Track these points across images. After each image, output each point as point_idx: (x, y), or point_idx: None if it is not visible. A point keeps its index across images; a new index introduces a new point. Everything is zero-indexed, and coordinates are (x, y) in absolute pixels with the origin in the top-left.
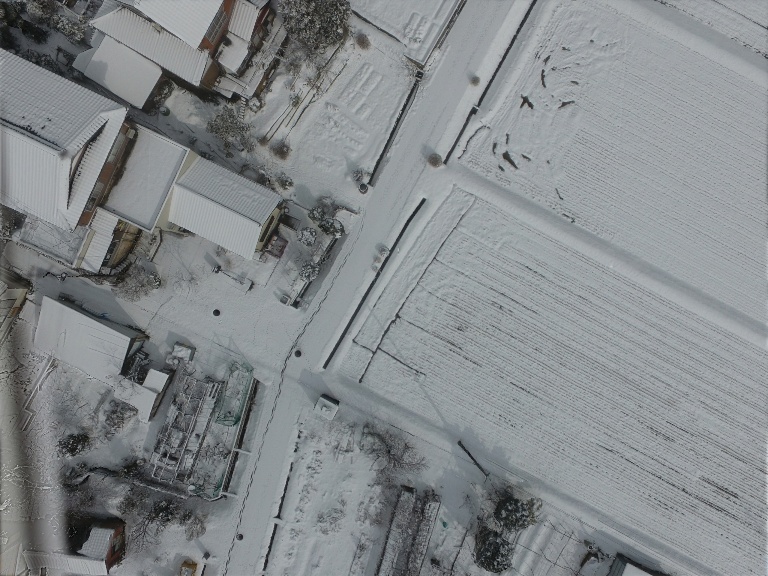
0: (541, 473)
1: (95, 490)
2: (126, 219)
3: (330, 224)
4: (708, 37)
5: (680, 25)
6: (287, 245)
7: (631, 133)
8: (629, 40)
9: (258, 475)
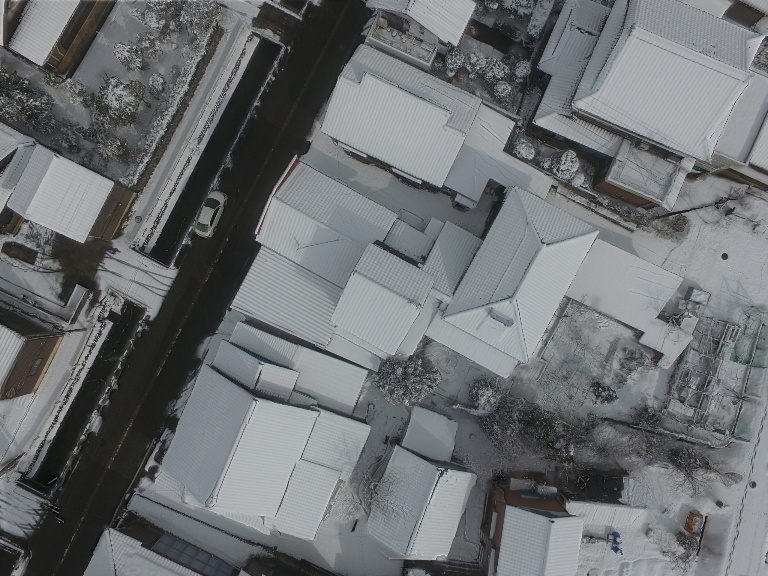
0: None
1: (603, 441)
2: (720, 153)
3: None
4: None
5: None
6: None
7: None
8: None
9: None
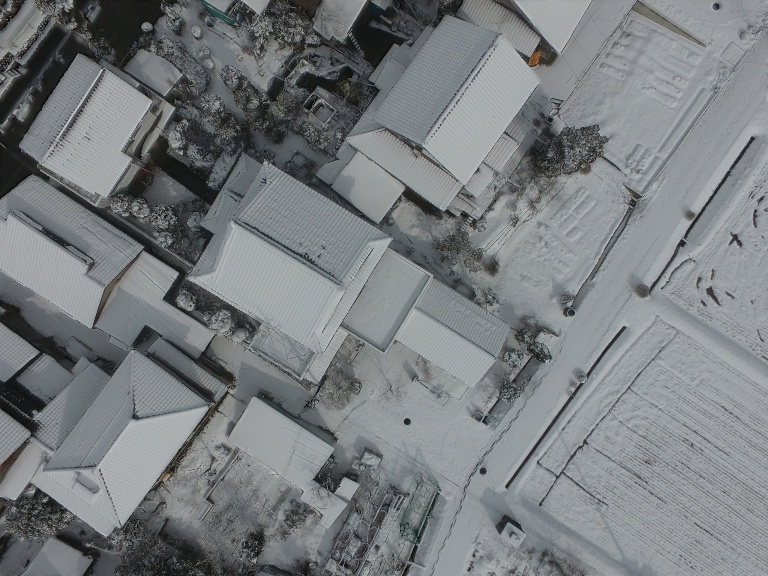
0: None
1: None
2: (361, 338)
3: (539, 349)
4: None
5: None
6: None
7: None
8: None
9: None
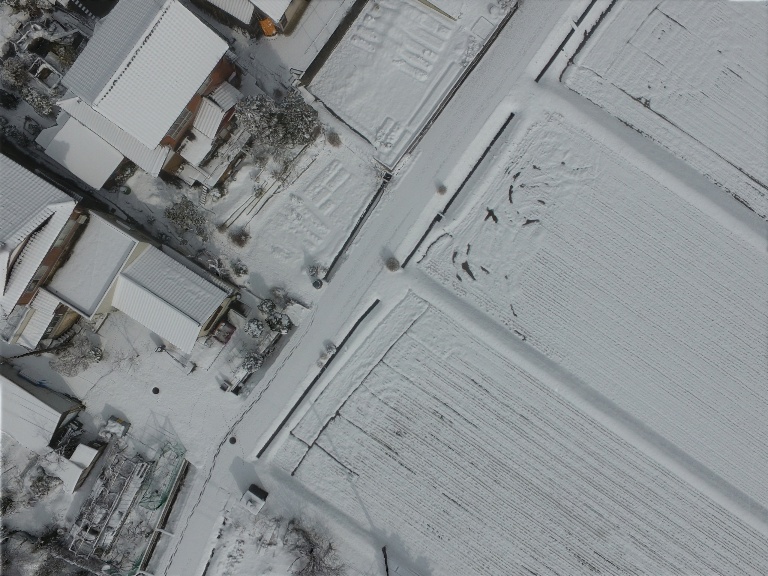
0: None
1: (12, 553)
2: (67, 303)
3: (278, 320)
4: (679, 173)
5: (652, 159)
6: (235, 331)
7: (592, 259)
8: (600, 167)
9: (178, 558)
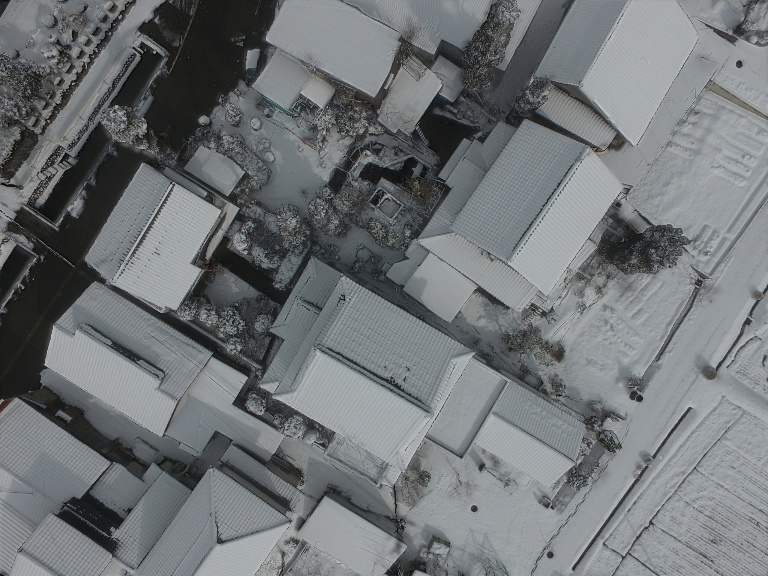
0: None
1: None
2: (438, 444)
3: (609, 438)
4: None
5: None
6: None
7: None
8: None
9: None
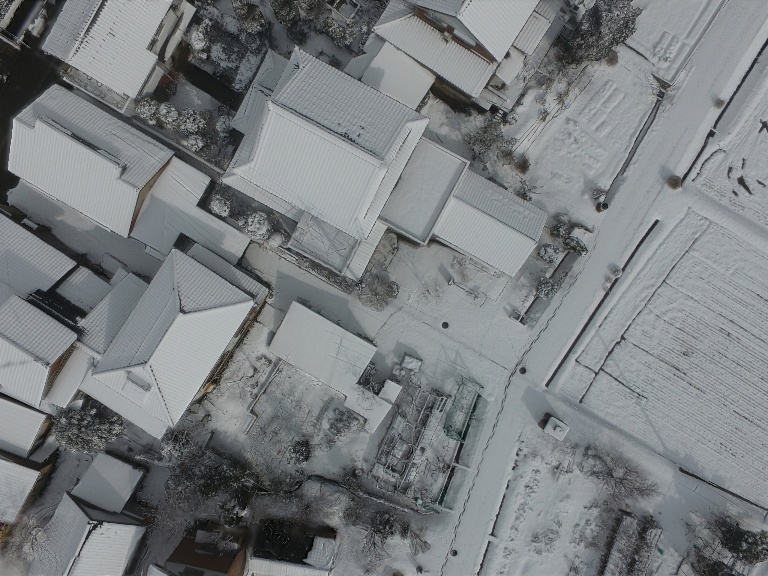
0: (760, 504)
1: (310, 497)
2: (400, 229)
3: (575, 242)
4: None
5: None
6: None
7: None
8: None
9: (476, 491)
